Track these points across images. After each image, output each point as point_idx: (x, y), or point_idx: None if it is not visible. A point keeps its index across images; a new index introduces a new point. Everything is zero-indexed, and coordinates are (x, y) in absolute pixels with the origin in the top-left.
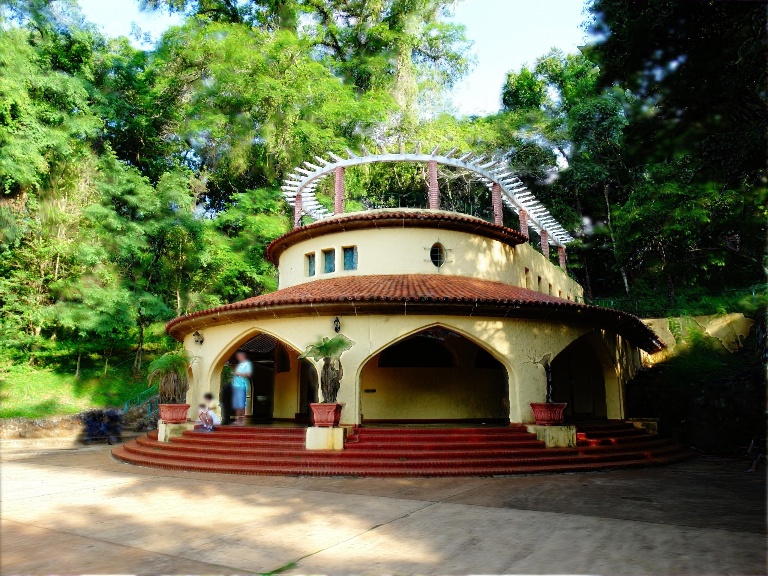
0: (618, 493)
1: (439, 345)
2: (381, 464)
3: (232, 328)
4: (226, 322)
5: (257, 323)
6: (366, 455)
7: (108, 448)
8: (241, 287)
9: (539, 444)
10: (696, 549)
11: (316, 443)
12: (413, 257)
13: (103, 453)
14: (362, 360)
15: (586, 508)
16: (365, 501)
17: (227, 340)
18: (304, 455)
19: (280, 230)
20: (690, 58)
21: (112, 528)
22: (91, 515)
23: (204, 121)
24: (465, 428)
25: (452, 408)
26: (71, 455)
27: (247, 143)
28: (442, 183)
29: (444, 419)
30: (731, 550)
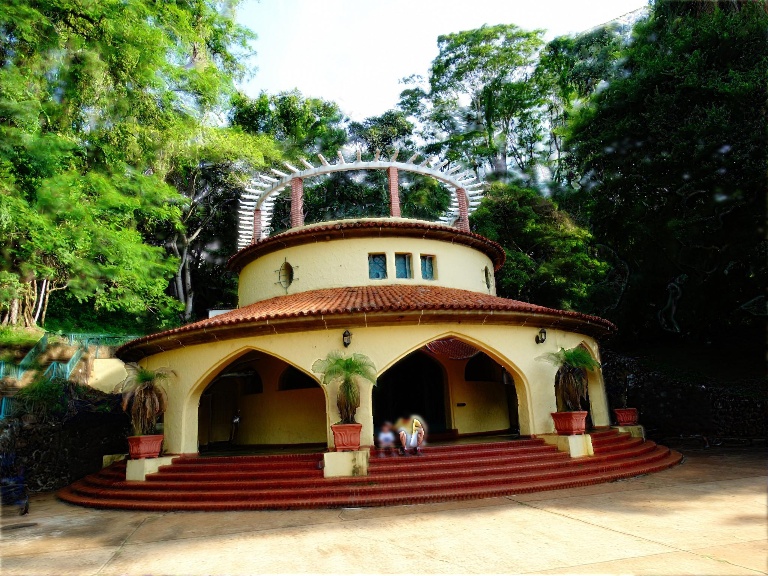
0: None
1: (489, 361)
2: (640, 462)
3: (417, 330)
4: (409, 323)
5: (457, 327)
6: (619, 456)
7: (84, 514)
8: (45, 267)
9: None
10: None
11: (577, 450)
12: (477, 277)
13: (169, 514)
14: (556, 371)
15: None
16: None
17: (410, 344)
18: (585, 462)
19: (136, 202)
20: (760, 193)
21: None
22: None
23: (12, 9)
24: None
25: (505, 419)
26: (142, 524)
27: (51, 64)
28: (181, 183)
29: (505, 430)
30: None
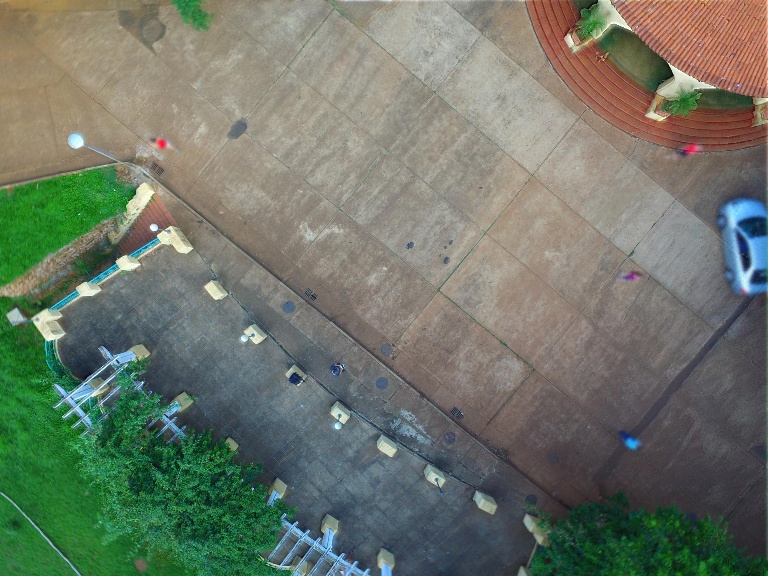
0: (736, 196)
1: None
2: None
3: None
4: None
5: None
6: None
7: None
8: None
9: (748, 126)
10: (714, 259)
11: (650, 116)
12: None
13: (519, 0)
14: None
15: (713, 217)
16: (655, 193)
17: None
18: (642, 122)
19: None
20: None
21: (588, 212)
22: (577, 194)
23: None
24: (723, 114)
25: None
26: (504, 8)
27: None
28: None
29: None
30: (720, 261)
